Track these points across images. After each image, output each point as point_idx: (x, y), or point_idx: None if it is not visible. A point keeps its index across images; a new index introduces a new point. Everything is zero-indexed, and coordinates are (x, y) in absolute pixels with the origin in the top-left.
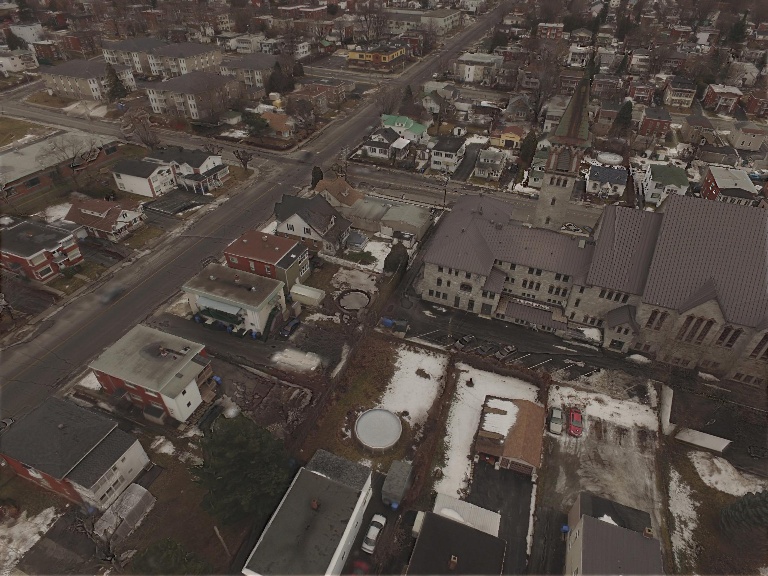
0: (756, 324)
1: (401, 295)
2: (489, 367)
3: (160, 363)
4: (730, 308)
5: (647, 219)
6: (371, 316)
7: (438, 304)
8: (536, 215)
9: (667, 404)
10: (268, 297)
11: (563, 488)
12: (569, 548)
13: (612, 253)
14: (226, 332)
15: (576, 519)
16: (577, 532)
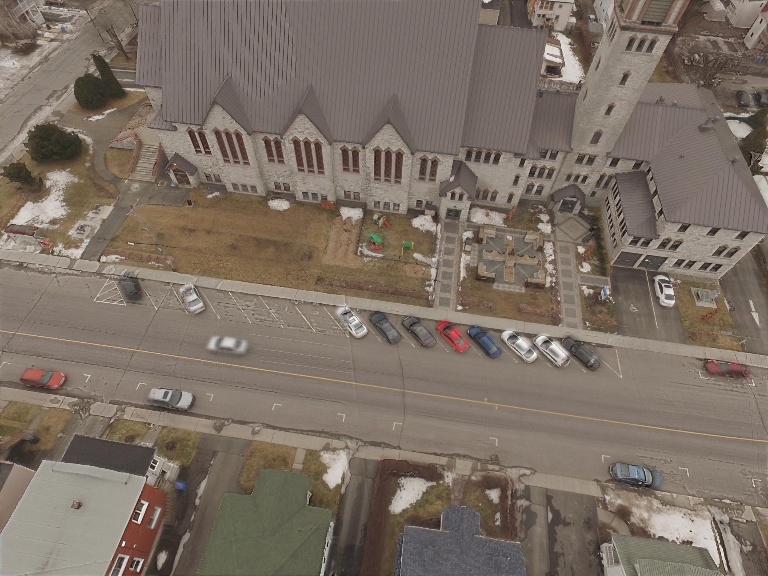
0: None
1: None
2: None
3: None
4: None
5: None
6: None
7: None
8: None
9: None
10: None
11: None
12: None
13: None
14: None
15: None
16: None
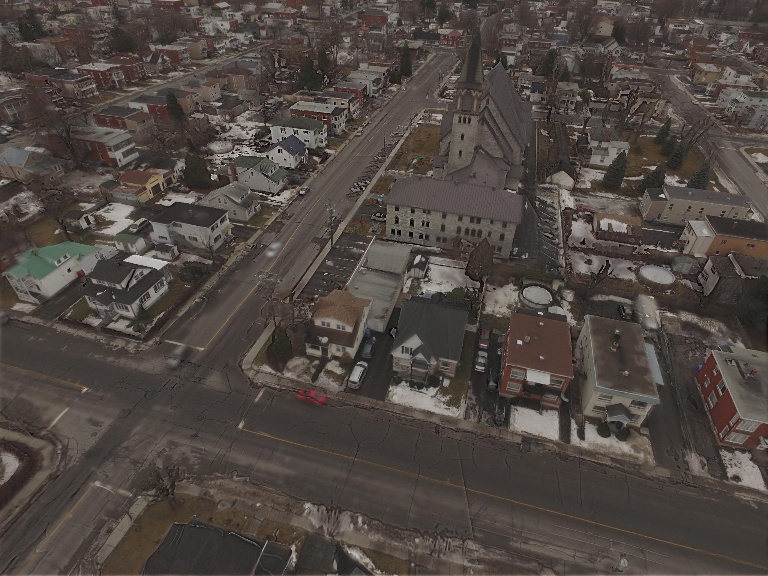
0: None
1: None
2: None
3: (761, 374)
4: None
5: None
6: None
7: None
8: None
9: (562, 179)
10: (618, 320)
11: None
12: (667, 218)
13: None
14: None
15: (661, 208)
16: (670, 207)
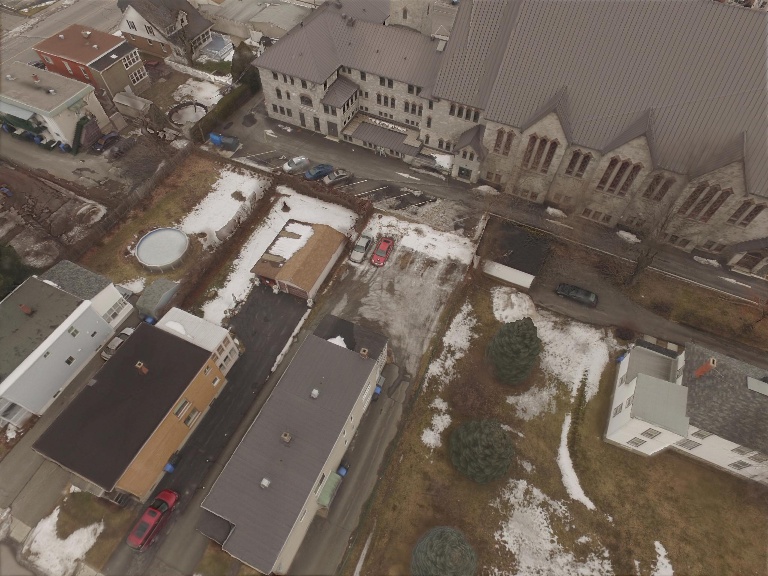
0: (603, 147)
1: (247, 111)
2: (312, 192)
3: None
4: (578, 126)
5: (509, 7)
6: (195, 131)
7: (285, 123)
8: (391, 5)
9: None
10: (66, 101)
11: (338, 314)
12: None
13: (464, 55)
14: (35, 143)
15: None
16: None
